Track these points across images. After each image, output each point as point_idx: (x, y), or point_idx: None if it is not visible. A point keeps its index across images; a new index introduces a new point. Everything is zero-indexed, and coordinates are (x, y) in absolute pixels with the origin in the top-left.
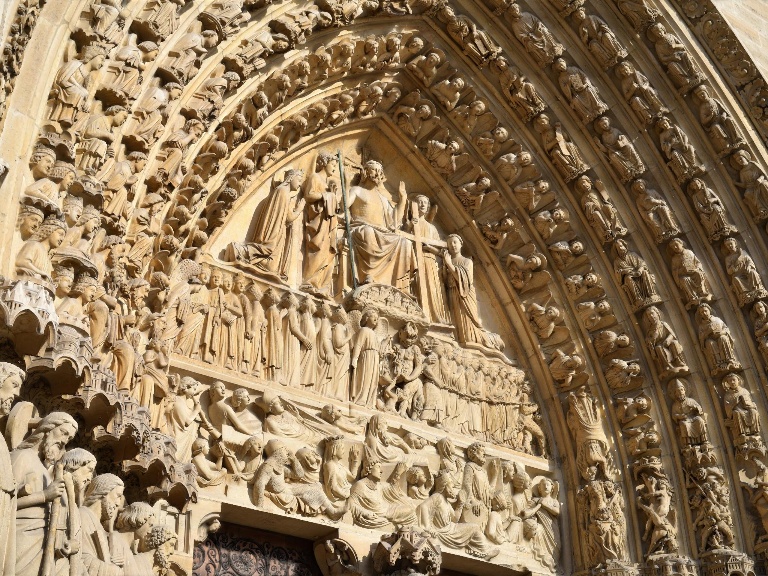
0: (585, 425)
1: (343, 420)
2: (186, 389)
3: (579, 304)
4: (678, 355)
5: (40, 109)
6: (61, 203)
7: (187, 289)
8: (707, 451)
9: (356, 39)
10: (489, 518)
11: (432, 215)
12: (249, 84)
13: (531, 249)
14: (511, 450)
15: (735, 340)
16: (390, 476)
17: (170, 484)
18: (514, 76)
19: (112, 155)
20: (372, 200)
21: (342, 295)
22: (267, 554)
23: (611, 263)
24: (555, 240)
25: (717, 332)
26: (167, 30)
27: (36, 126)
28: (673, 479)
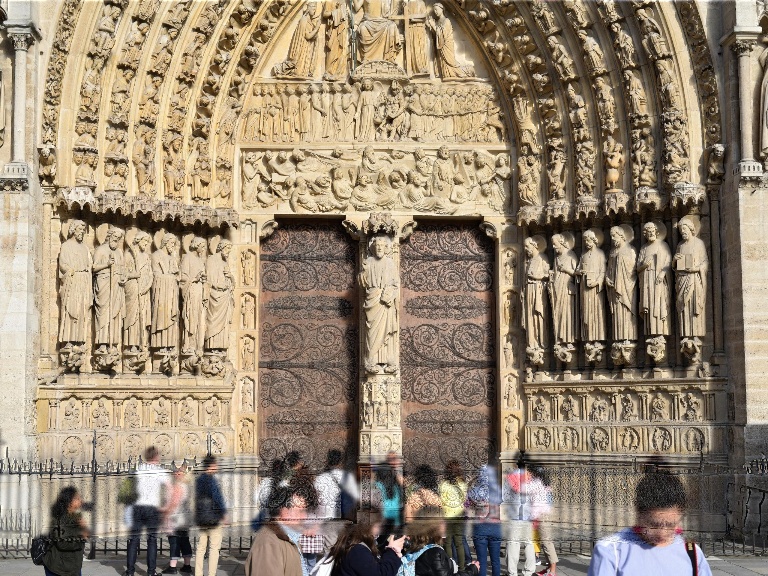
0: (519, 120)
1: (346, 154)
2: (249, 160)
3: (513, 38)
4: (566, 69)
5: (77, 102)
6: (105, 132)
7: (230, 113)
8: (580, 133)
9: None
10: (452, 190)
11: None
12: None
13: None
14: (474, 143)
15: (605, 51)
16: (377, 180)
17: (219, 222)
18: None
19: (128, 97)
20: None
21: (350, 74)
22: (317, 230)
23: None
24: None
25: (587, 50)
26: (151, 12)
27: (76, 111)
28: (568, 150)
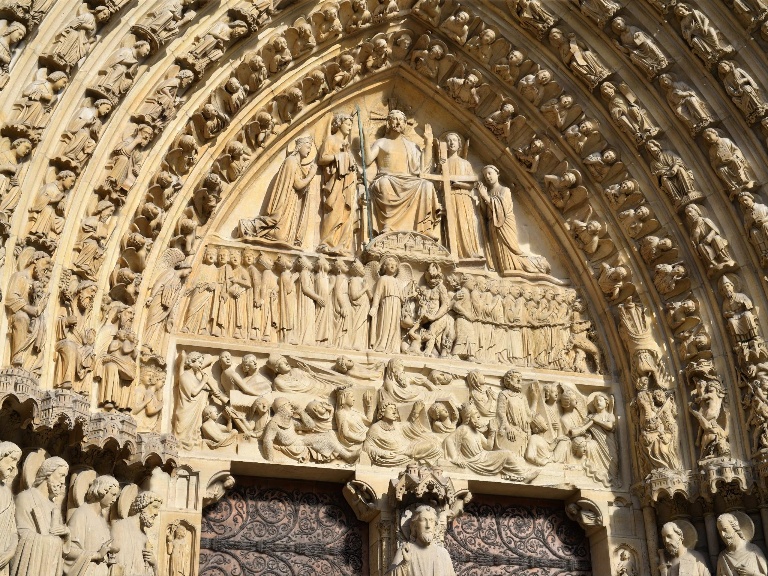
0: (633, 336)
1: (357, 369)
2: (191, 363)
3: (620, 214)
4: (720, 251)
5: None
6: None
7: (172, 275)
8: (754, 347)
9: (342, 1)
10: (528, 442)
11: (465, 151)
12: (219, 74)
13: (564, 167)
14: (557, 371)
15: None
16: (410, 415)
17: (144, 455)
18: None
19: (15, 184)
20: (395, 149)
21: (361, 248)
22: (296, 500)
23: (648, 166)
24: (589, 153)
25: (759, 220)
26: (75, 57)
27: None
28: (726, 380)
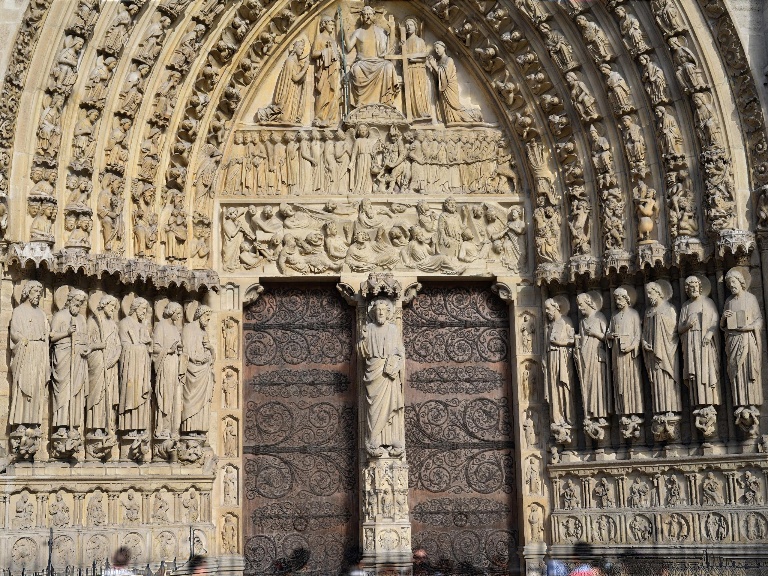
0: (534, 168)
1: (340, 208)
2: (230, 216)
3: (526, 77)
4: (588, 108)
5: (32, 145)
6: (66, 180)
7: (209, 163)
8: (606, 178)
9: None
10: (460, 247)
11: (420, 31)
12: (226, 16)
13: (487, 43)
14: (484, 194)
15: (632, 87)
16: (376, 237)
17: (197, 285)
18: None
19: (92, 140)
20: (367, 38)
21: (343, 119)
22: (308, 295)
23: None
24: (504, 31)
25: (611, 86)
26: (119, 45)
27: (32, 155)
28: (592, 199)
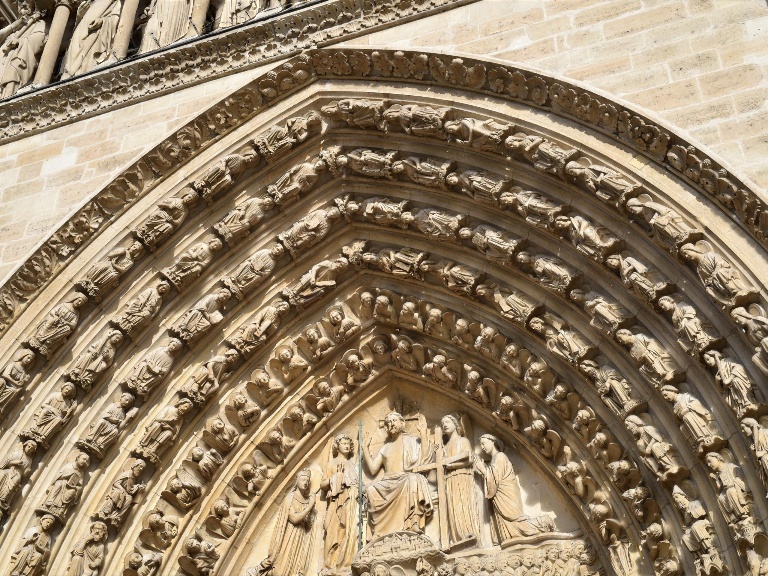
0: None
1: None
2: None
3: None
4: (660, 460)
5: None
6: None
7: None
8: (703, 563)
9: None
10: None
11: None
12: (185, 448)
13: None
14: None
15: (713, 408)
16: None
17: None
18: (439, 271)
19: None
20: (393, 452)
21: None
22: None
23: None
24: None
25: (679, 414)
26: (5, 492)
27: None
28: None
